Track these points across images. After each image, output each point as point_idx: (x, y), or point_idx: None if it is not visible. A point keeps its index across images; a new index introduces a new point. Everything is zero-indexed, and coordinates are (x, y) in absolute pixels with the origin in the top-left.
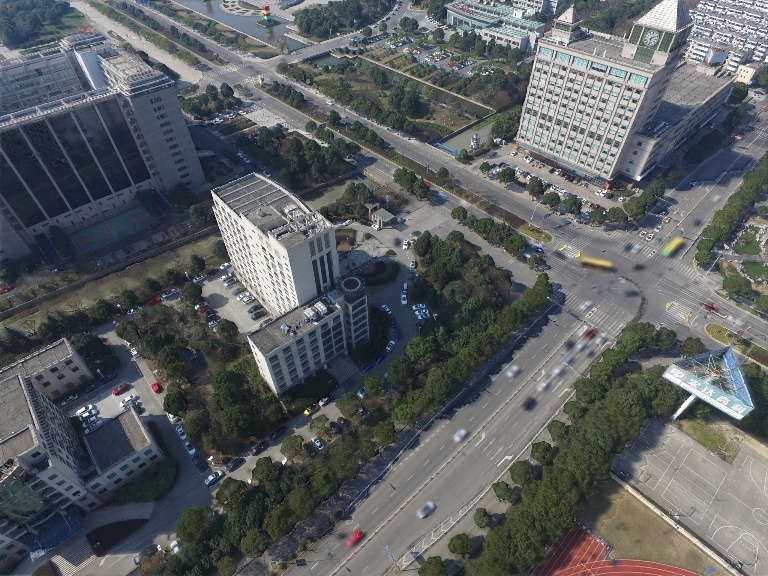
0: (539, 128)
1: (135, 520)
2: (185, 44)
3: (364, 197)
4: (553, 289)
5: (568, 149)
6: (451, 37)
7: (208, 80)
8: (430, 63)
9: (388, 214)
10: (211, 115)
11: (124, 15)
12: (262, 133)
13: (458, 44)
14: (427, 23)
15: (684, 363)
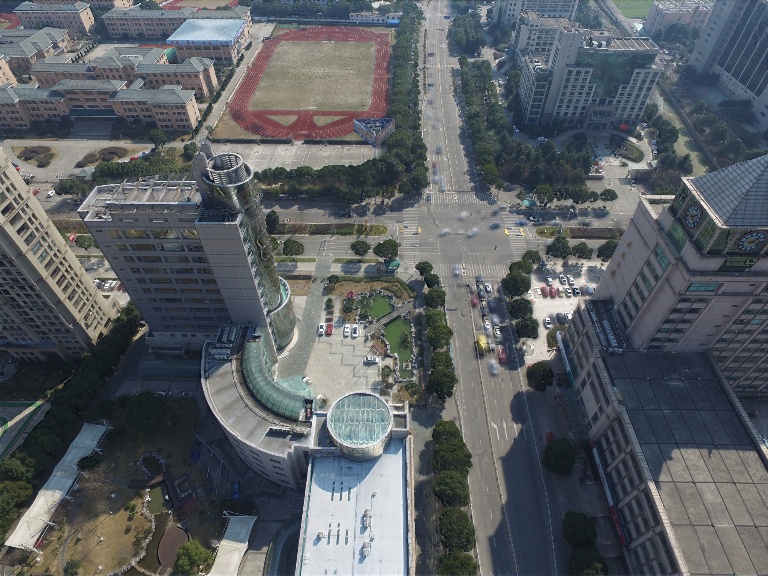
0: None
1: (501, 68)
2: None
3: None
4: (491, 199)
5: None
6: None
7: None
8: None
9: (638, 167)
10: None
11: None
12: None
13: None
14: None
15: (390, 125)
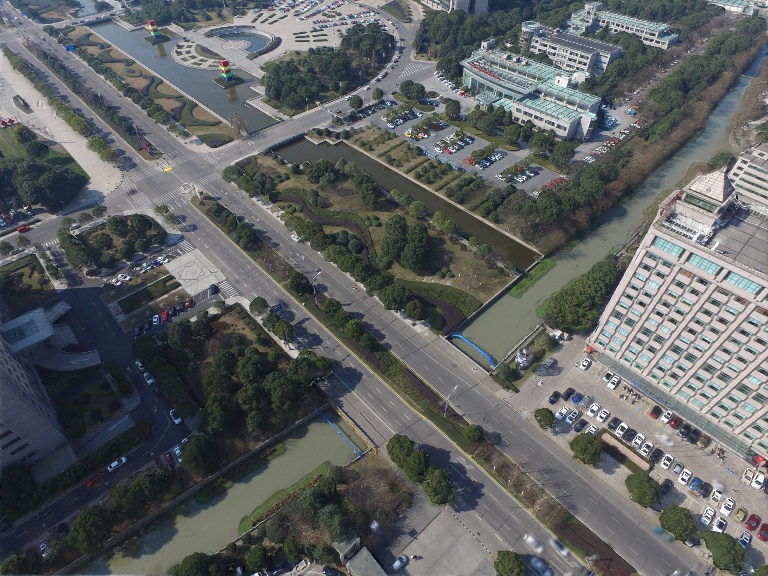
0: (635, 343)
1: None
2: (109, 121)
3: (330, 533)
4: None
5: (689, 389)
6: (471, 116)
7: (127, 188)
8: (443, 160)
9: (375, 569)
10: (114, 265)
11: (44, 68)
12: (173, 335)
13: (480, 126)
14: (436, 83)
15: None
